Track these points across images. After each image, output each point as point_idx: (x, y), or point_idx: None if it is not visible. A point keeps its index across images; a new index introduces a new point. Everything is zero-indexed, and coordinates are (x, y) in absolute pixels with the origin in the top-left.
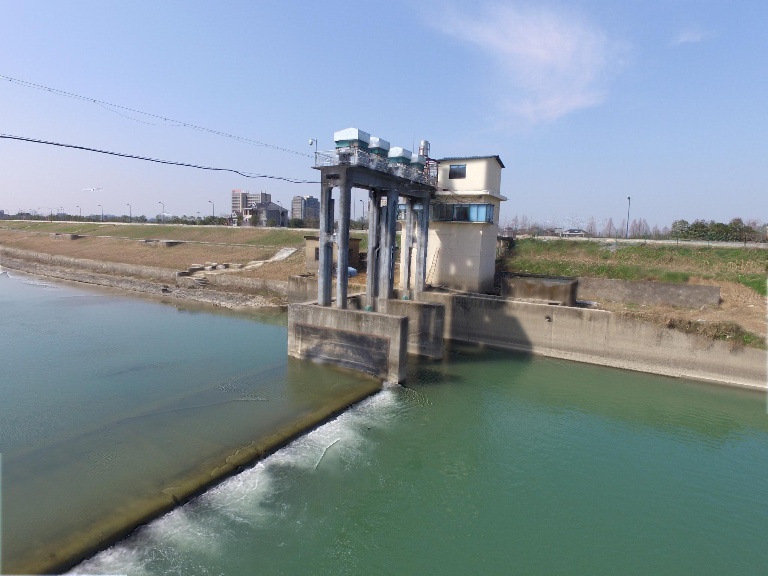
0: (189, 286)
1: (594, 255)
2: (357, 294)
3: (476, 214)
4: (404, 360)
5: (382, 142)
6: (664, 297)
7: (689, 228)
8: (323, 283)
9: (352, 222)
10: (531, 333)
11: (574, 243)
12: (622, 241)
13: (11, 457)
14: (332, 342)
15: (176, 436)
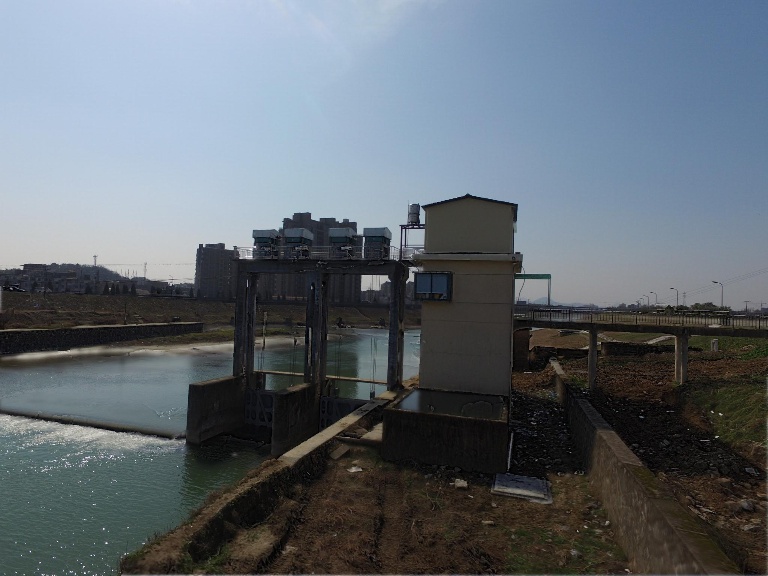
0: None
1: None
2: None
3: None
4: (195, 424)
5: (290, 231)
6: (653, 569)
7: None
8: None
9: None
10: None
11: None
12: None
13: (105, 397)
14: None
15: (109, 409)
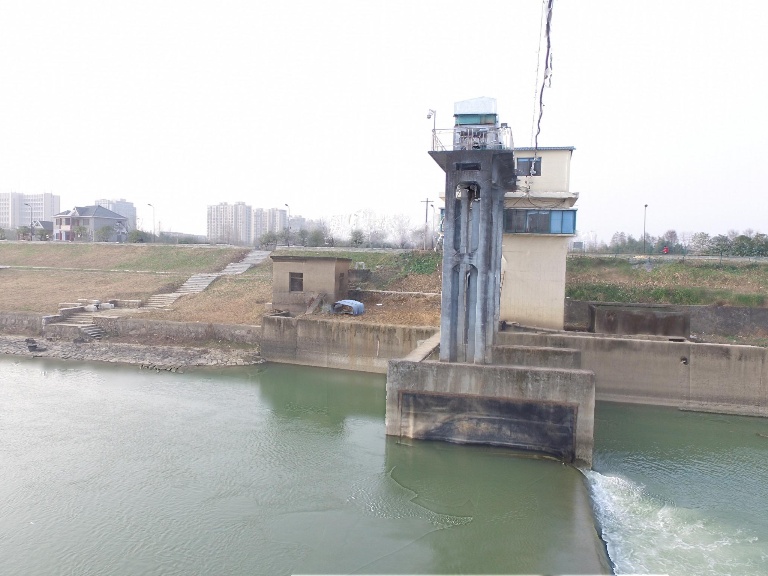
0: (75, 339)
1: (630, 275)
2: (438, 340)
3: (560, 224)
4: None
5: None
6: (763, 325)
7: (711, 241)
8: (450, 326)
9: (271, 235)
10: (661, 381)
11: (600, 261)
12: (655, 258)
13: None
14: (473, 416)
15: None
